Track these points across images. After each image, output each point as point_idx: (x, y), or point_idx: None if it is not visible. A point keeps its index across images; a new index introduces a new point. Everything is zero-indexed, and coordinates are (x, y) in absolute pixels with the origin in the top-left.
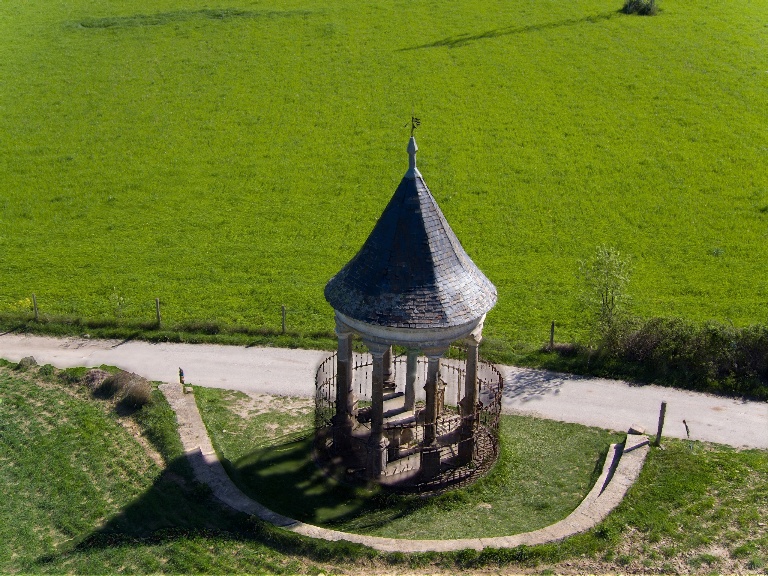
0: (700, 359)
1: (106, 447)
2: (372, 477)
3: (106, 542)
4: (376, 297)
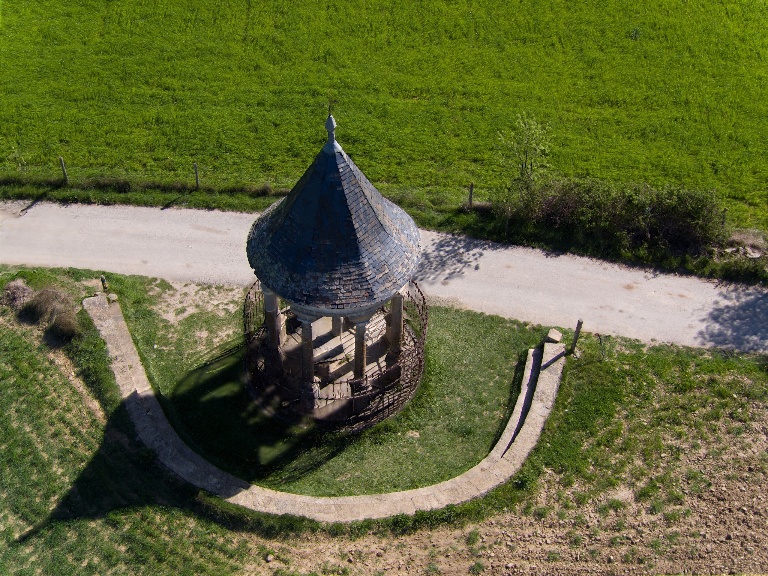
0: (615, 227)
1: (44, 397)
2: (306, 412)
3: (65, 529)
4: (302, 276)
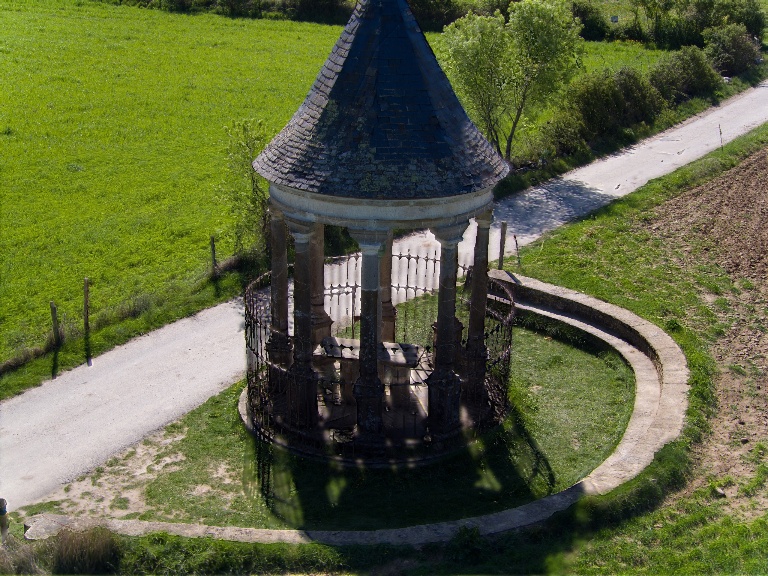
0: None
1: None
2: (456, 428)
3: None
4: (451, 156)
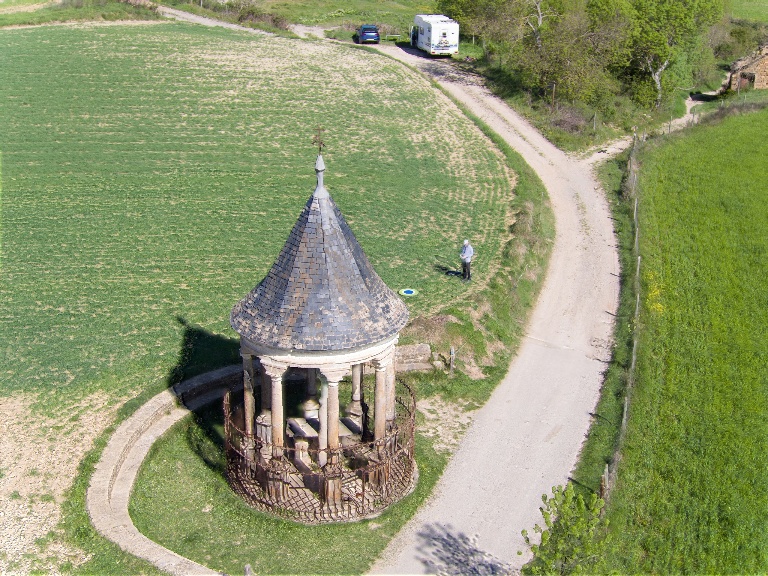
0: None
1: None
2: None
3: None
4: None
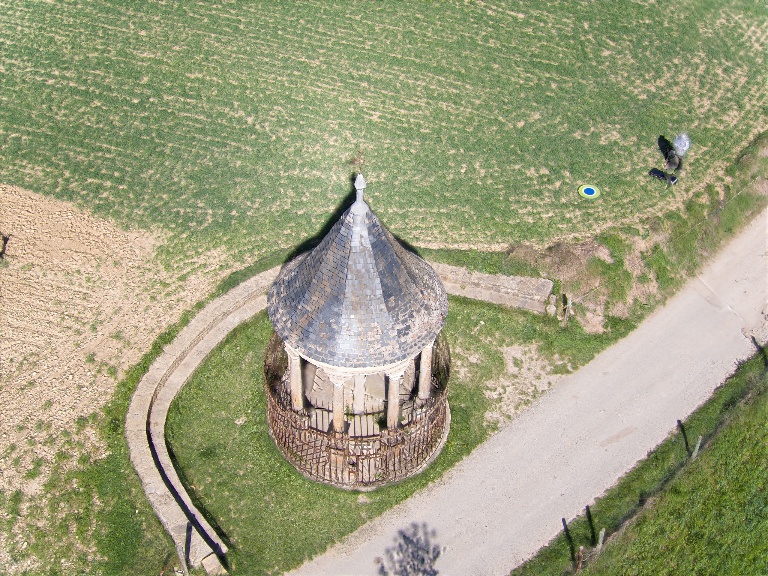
0: None
1: None
2: None
3: None
4: None
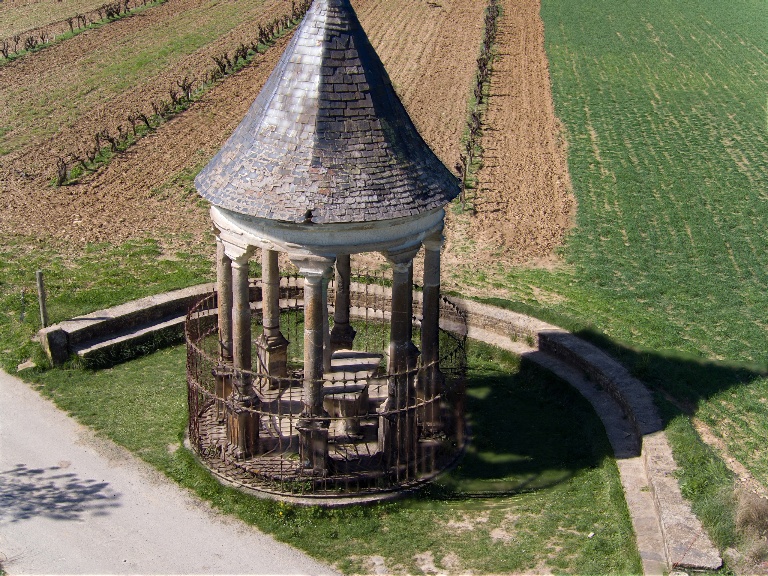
0: None
1: None
2: None
3: None
4: None
